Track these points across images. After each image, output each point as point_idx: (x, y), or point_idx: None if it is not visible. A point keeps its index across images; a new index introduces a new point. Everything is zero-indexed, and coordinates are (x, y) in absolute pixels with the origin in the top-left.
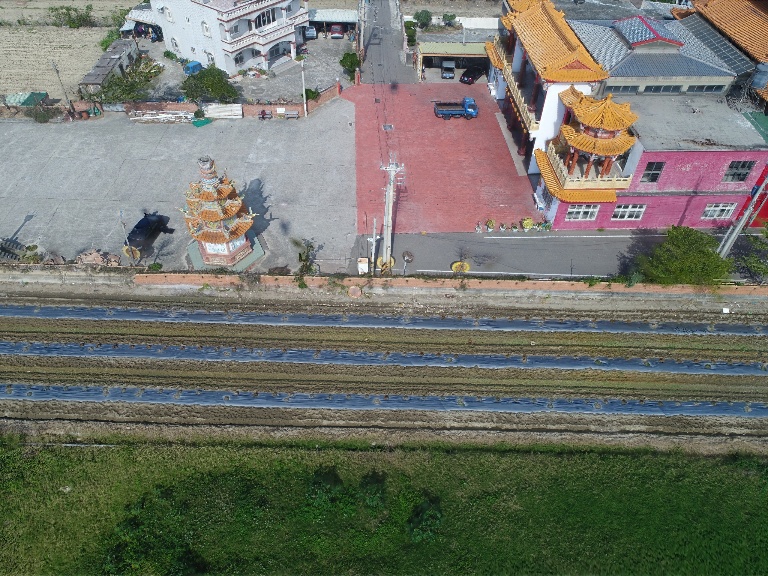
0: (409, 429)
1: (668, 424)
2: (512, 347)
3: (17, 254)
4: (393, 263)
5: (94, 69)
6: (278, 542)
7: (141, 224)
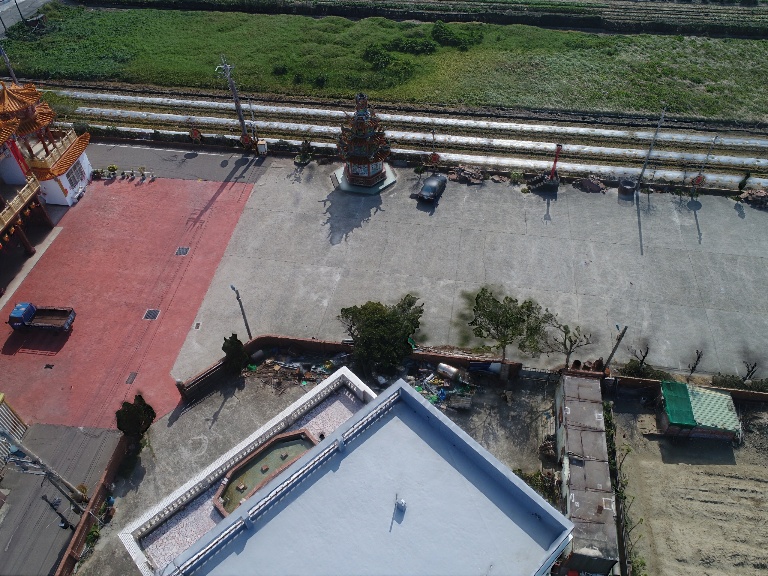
0: (271, 100)
1: None
2: (191, 125)
3: None
4: (241, 141)
5: (599, 423)
6: None
7: None
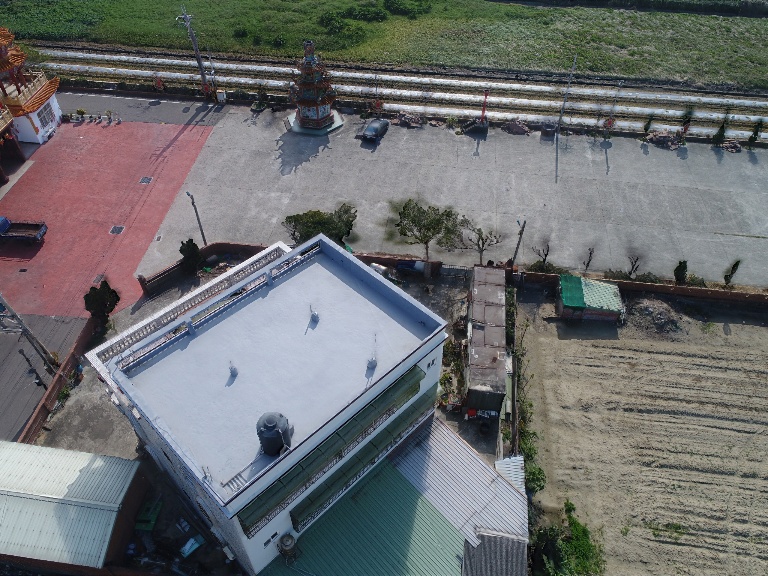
0: (232, 59)
1: (108, 53)
2: None
3: None
4: (201, 90)
5: (501, 300)
6: None
7: None
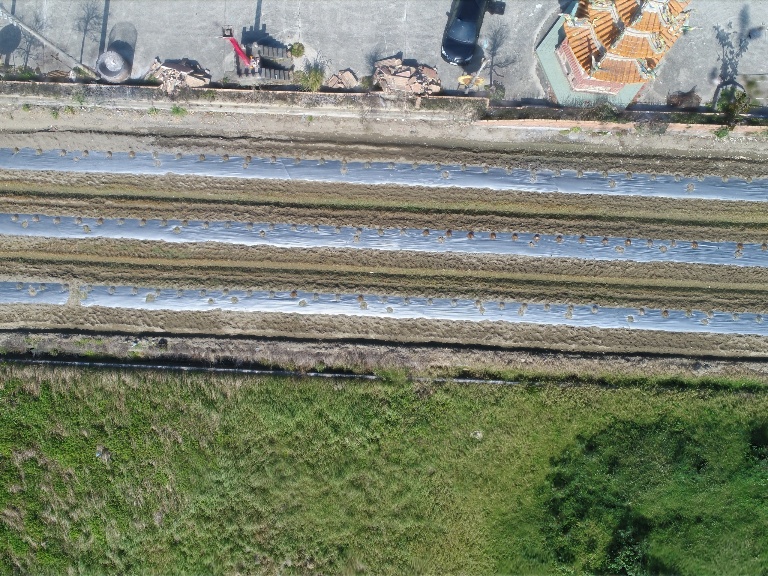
0: None
1: None
2: None
3: (281, 65)
4: None
5: None
6: (720, 504)
7: (463, 7)
